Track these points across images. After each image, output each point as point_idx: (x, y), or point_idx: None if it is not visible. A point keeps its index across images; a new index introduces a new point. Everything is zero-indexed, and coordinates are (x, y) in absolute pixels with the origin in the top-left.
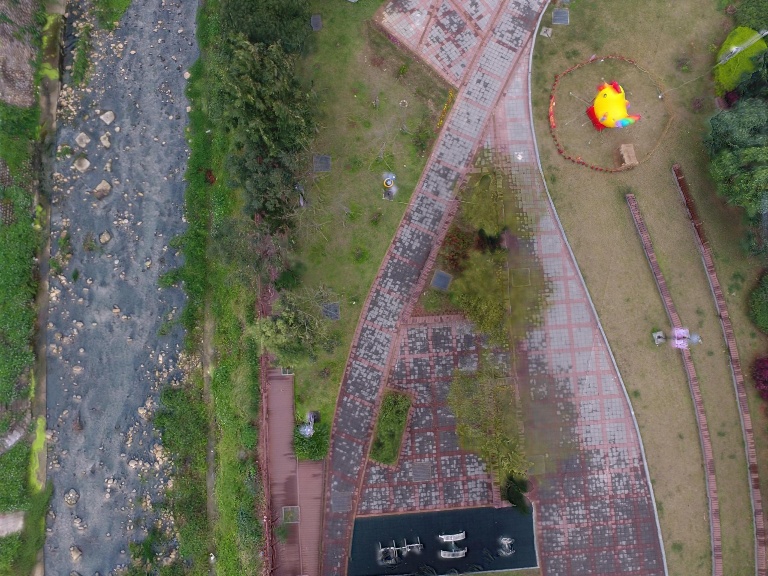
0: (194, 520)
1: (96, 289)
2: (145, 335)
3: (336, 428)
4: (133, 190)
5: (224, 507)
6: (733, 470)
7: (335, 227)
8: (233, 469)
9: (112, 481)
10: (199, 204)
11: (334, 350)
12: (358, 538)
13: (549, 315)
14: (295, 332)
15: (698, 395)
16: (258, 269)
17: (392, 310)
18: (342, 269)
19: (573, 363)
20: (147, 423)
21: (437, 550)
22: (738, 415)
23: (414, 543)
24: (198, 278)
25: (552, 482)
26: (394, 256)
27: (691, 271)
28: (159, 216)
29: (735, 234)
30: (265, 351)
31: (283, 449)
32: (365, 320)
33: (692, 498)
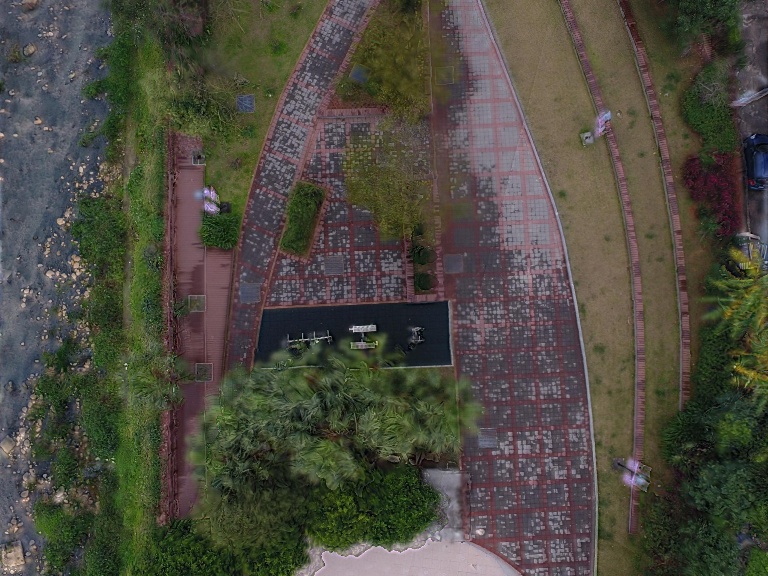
0: (108, 327)
1: (18, 100)
2: (66, 147)
3: (247, 219)
4: (59, 4)
5: (134, 305)
6: (660, 273)
7: (253, 19)
8: (143, 265)
9: (28, 290)
10: (124, 15)
11: (248, 141)
12: (266, 329)
13: (472, 113)
14: (208, 122)
15: (625, 195)
16: (170, 54)
17: (309, 104)
18: (259, 61)
19: (496, 162)
20: (65, 234)
21: (347, 343)
22: (667, 217)
23: (323, 335)
24: (120, 88)
25: (470, 281)
26: (313, 50)
27: (622, 71)
28: (84, 30)
29: (669, 33)
30: (176, 140)
31: (191, 238)
32: (281, 113)
33: (616, 301)
